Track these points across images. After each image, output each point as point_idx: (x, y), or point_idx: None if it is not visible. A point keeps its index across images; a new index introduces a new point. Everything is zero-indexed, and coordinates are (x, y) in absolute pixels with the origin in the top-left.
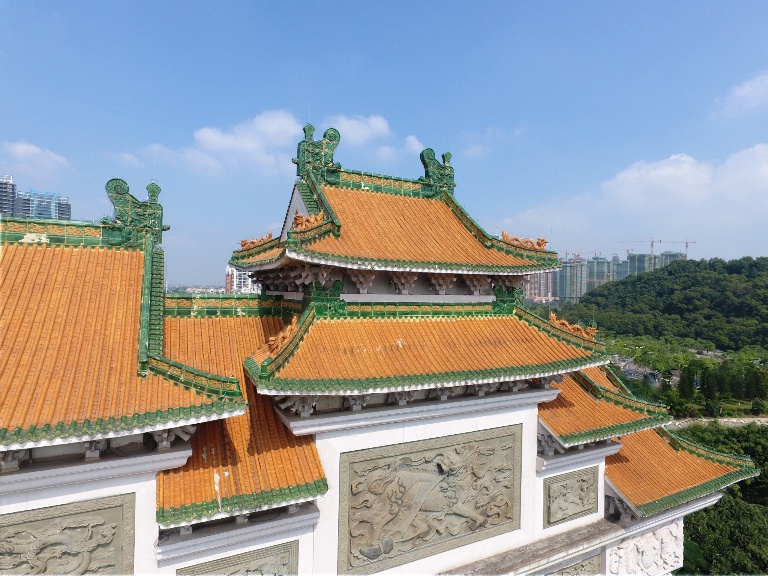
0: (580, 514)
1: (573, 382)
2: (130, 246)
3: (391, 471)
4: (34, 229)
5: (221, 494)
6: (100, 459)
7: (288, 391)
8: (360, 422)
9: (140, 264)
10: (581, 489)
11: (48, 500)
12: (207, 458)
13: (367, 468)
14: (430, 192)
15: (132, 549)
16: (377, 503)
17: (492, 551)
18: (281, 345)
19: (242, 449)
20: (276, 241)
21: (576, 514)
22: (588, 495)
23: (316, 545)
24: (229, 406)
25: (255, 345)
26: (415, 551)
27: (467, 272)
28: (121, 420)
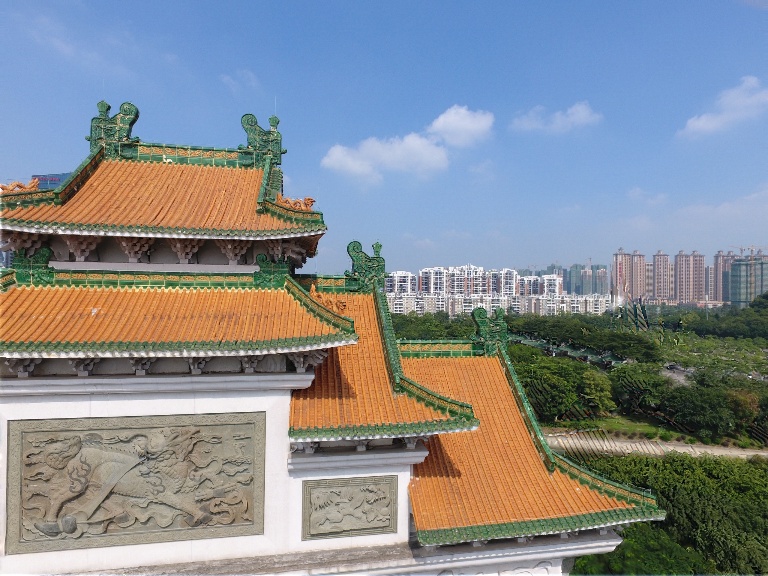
0: (366, 531)
1: (385, 372)
2: None
3: (70, 446)
4: None
5: None
6: None
7: None
8: (21, 389)
9: None
10: (366, 500)
11: None
12: None
13: (42, 439)
14: (250, 160)
15: None
16: (58, 478)
17: (219, 554)
18: None
19: None
20: None
21: (359, 530)
22: (377, 509)
23: None
24: None
25: None
26: (108, 536)
27: (186, 236)
28: None
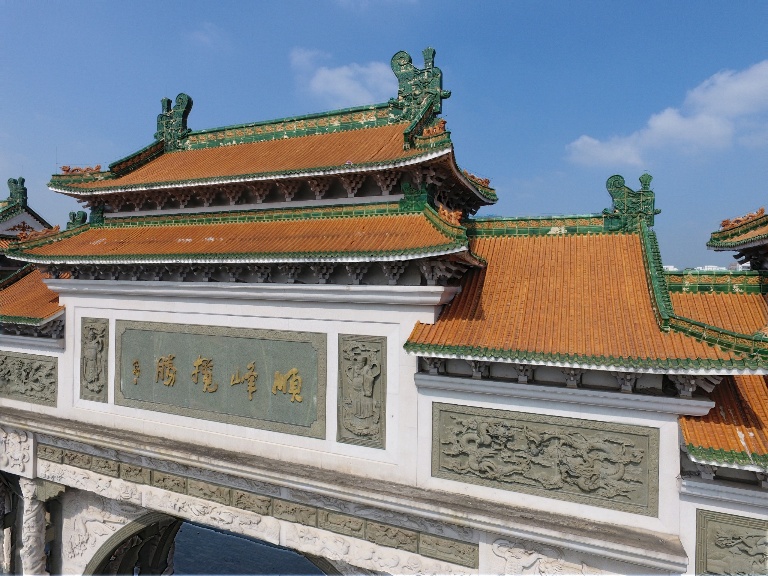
0: None
1: None
2: (626, 230)
3: None
4: (557, 224)
5: (750, 449)
6: (633, 393)
7: None
8: None
9: (637, 245)
10: None
11: (594, 415)
12: (726, 416)
13: None
14: None
15: (657, 475)
16: None
17: None
18: None
19: (764, 417)
20: None
21: None
22: None
23: None
24: (763, 364)
25: (760, 322)
26: None
27: None
28: (657, 361)
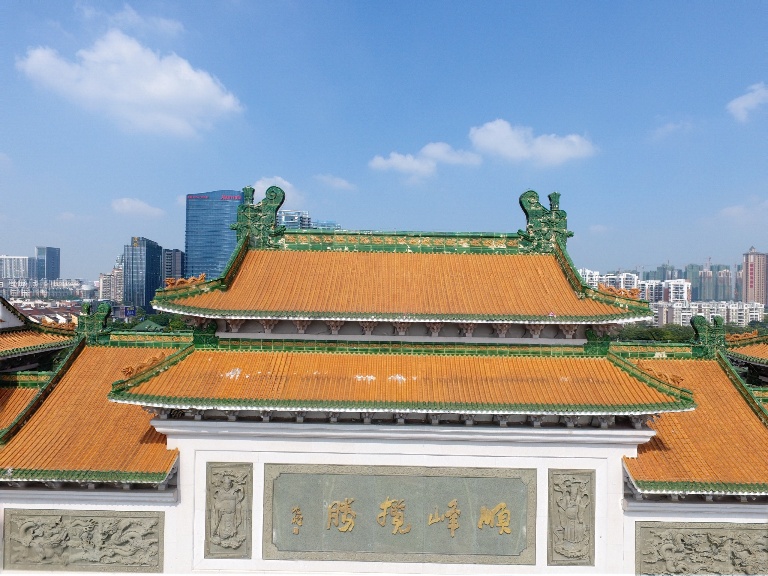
0: None
1: None
2: (708, 357)
3: None
4: (659, 350)
5: None
6: None
7: None
8: None
9: None
10: None
11: (756, 520)
12: None
13: None
14: None
15: None
16: None
17: None
18: None
19: None
20: (763, 337)
21: None
22: None
23: None
24: None
25: None
26: None
27: None
28: None
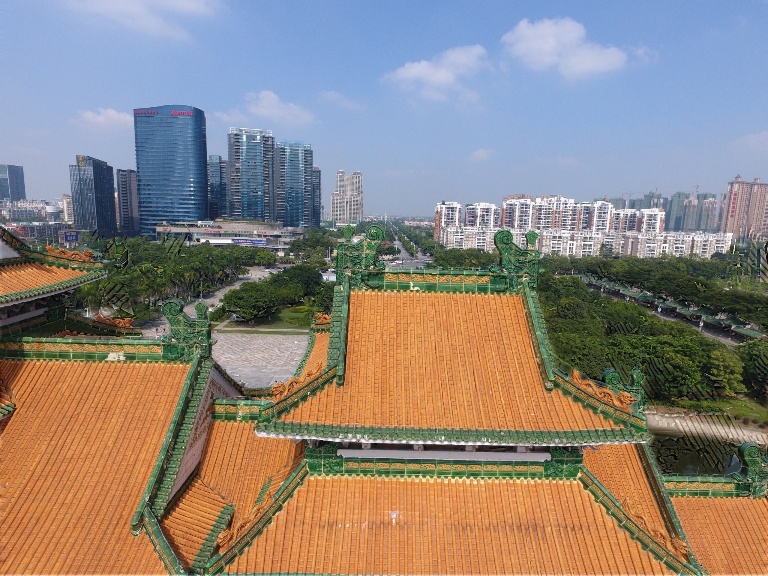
0: None
1: None
2: (184, 360)
3: None
4: (115, 349)
5: None
6: None
7: None
8: None
9: None
10: None
11: None
12: None
13: None
14: (503, 285)
15: None
16: None
17: None
18: (238, 534)
19: None
20: None
21: None
22: None
23: None
24: None
25: (283, 461)
26: None
27: (490, 443)
28: None
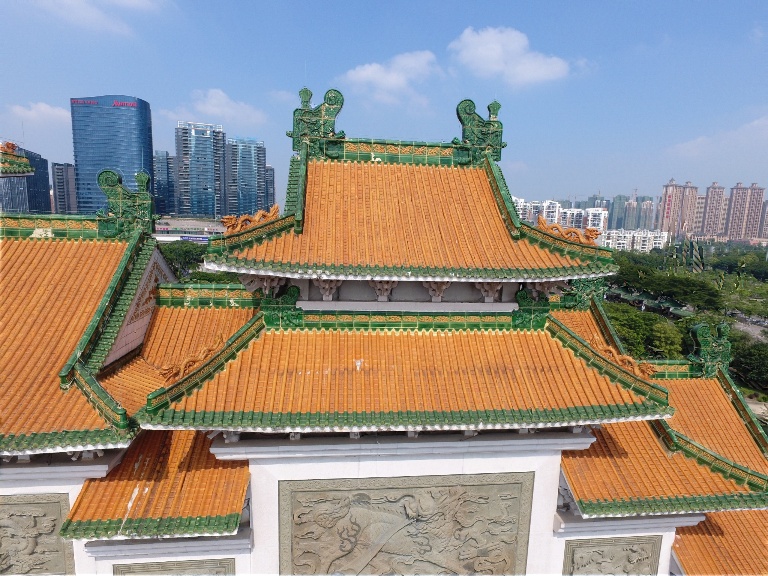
0: None
1: None
2: (123, 238)
3: (341, 507)
4: (41, 224)
5: (129, 514)
6: (29, 462)
7: (179, 426)
8: (296, 454)
9: None
10: (628, 560)
11: None
12: (138, 469)
13: (312, 499)
14: (466, 158)
15: None
16: (326, 536)
17: None
18: (185, 371)
19: (175, 463)
20: None
21: None
22: (639, 569)
23: (254, 567)
24: (114, 437)
25: None
26: None
27: (458, 279)
28: (18, 439)
